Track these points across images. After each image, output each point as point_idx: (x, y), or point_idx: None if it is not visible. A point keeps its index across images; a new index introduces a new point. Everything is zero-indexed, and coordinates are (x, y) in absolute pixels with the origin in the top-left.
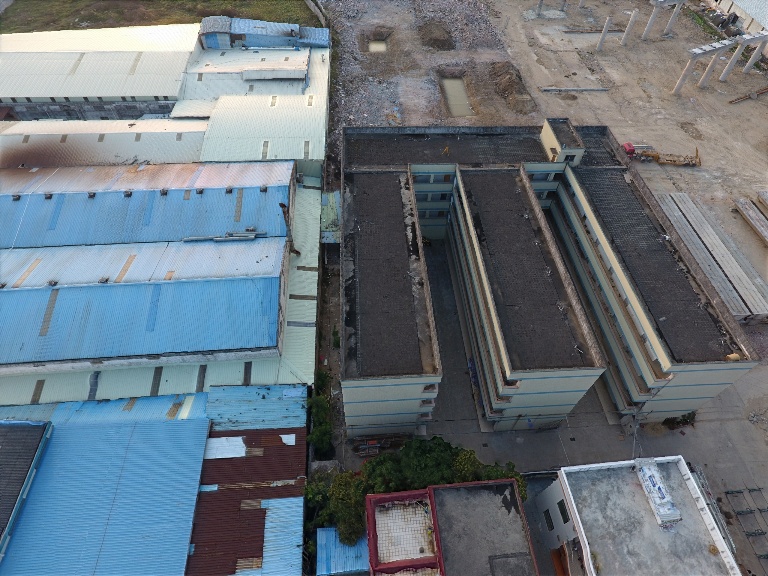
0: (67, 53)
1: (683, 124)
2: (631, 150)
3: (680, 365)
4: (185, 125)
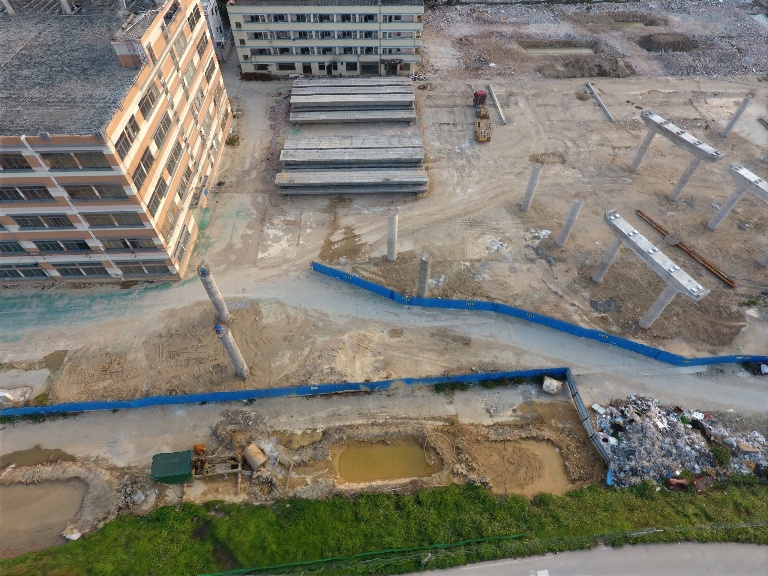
0: None
1: (560, 156)
2: None
3: None
4: None
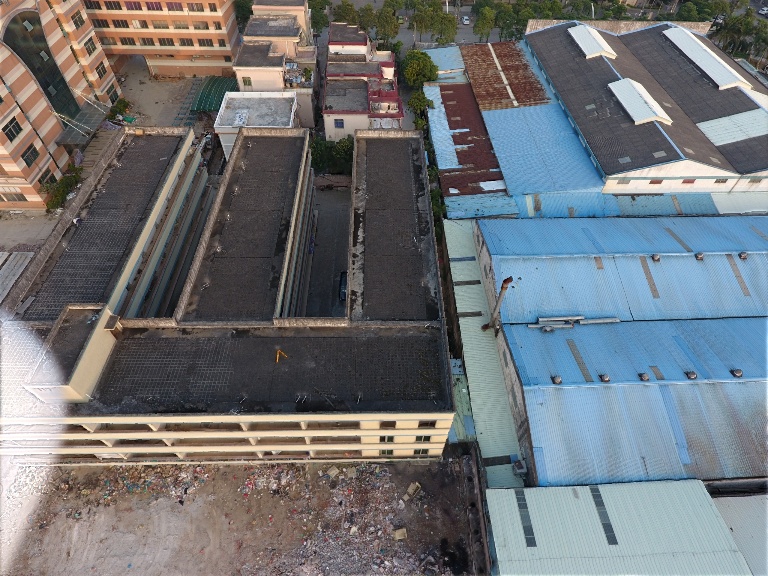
0: None
1: None
2: None
3: (186, 127)
4: None
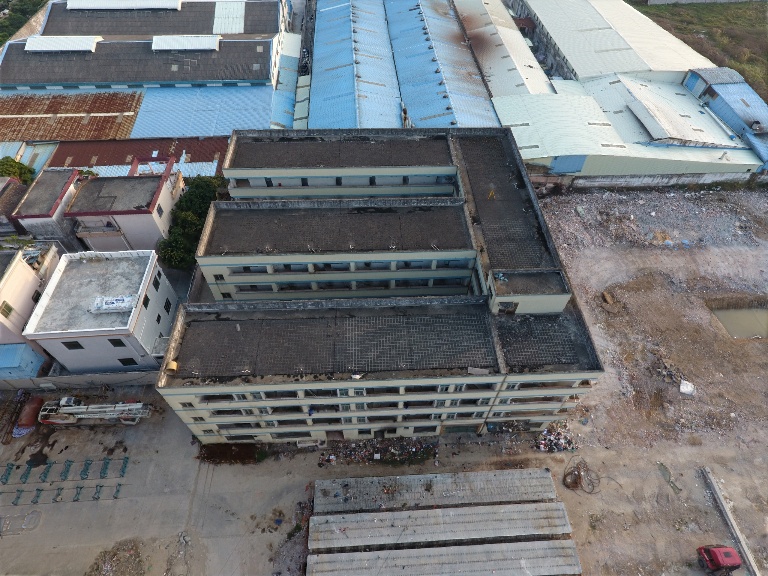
0: (606, 22)
1: None
2: (715, 556)
3: (179, 311)
4: (539, 87)
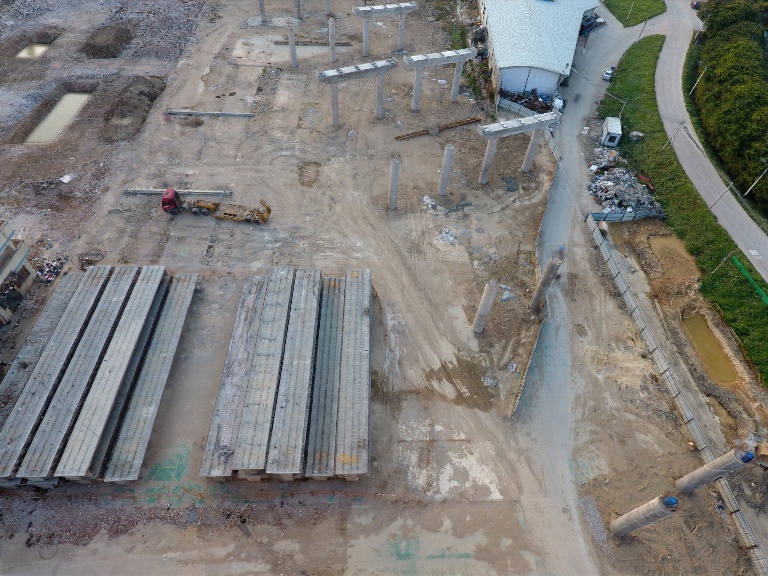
0: None
1: (306, 164)
2: (166, 199)
3: None
4: None
